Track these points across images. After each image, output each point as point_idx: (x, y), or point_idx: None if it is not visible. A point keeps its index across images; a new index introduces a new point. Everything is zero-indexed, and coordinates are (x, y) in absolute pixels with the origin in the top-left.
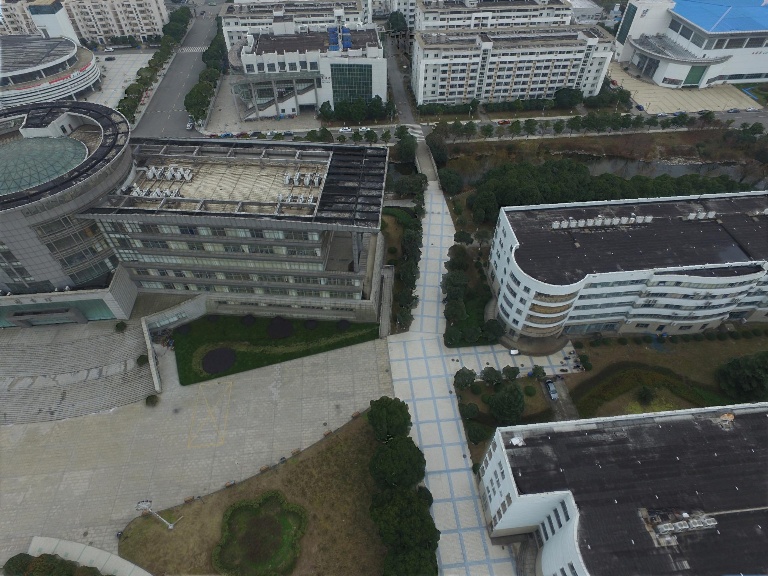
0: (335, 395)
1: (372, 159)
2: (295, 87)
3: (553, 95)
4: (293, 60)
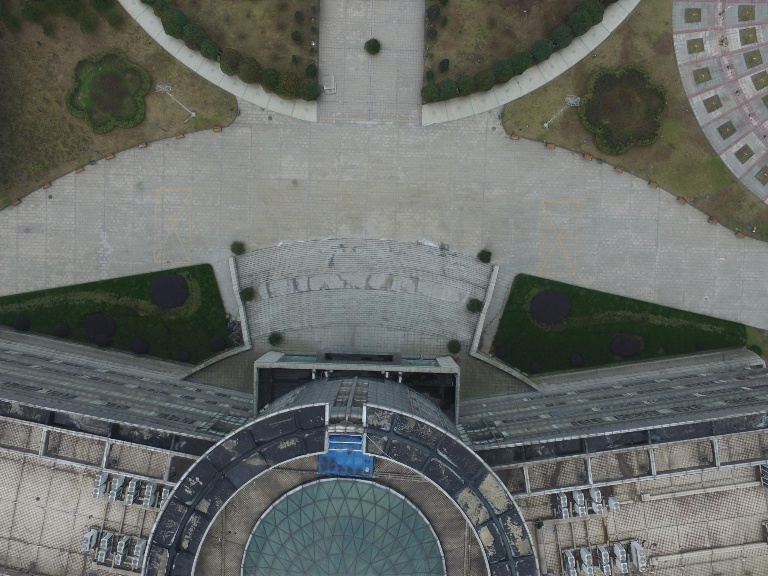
0: (38, 230)
1: None
2: None
3: None
4: None
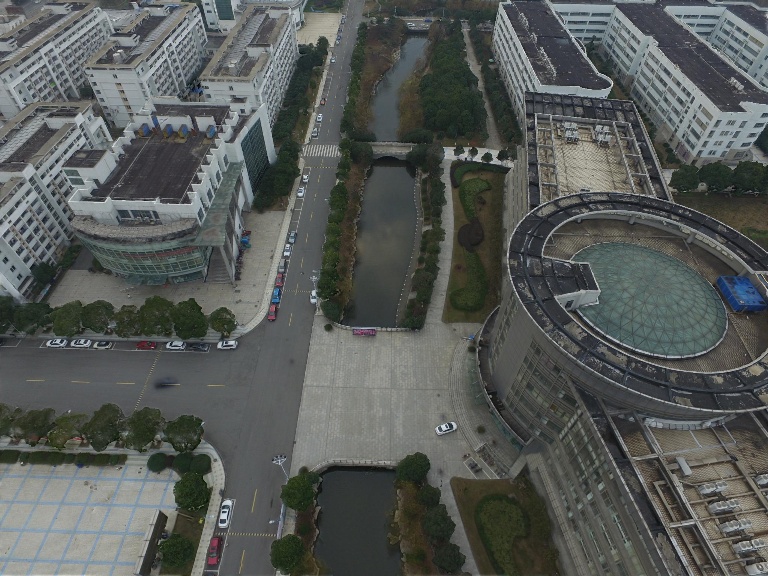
0: None
1: (542, 98)
2: (235, 197)
3: (291, 70)
4: (216, 169)
